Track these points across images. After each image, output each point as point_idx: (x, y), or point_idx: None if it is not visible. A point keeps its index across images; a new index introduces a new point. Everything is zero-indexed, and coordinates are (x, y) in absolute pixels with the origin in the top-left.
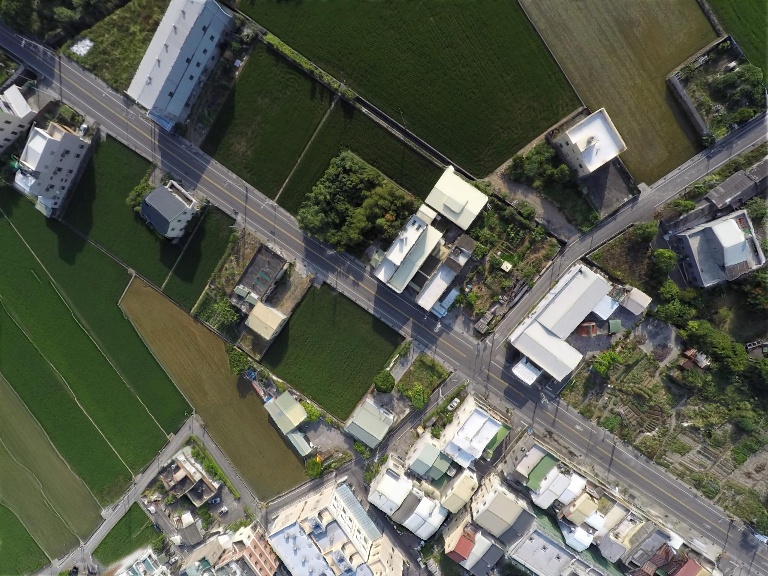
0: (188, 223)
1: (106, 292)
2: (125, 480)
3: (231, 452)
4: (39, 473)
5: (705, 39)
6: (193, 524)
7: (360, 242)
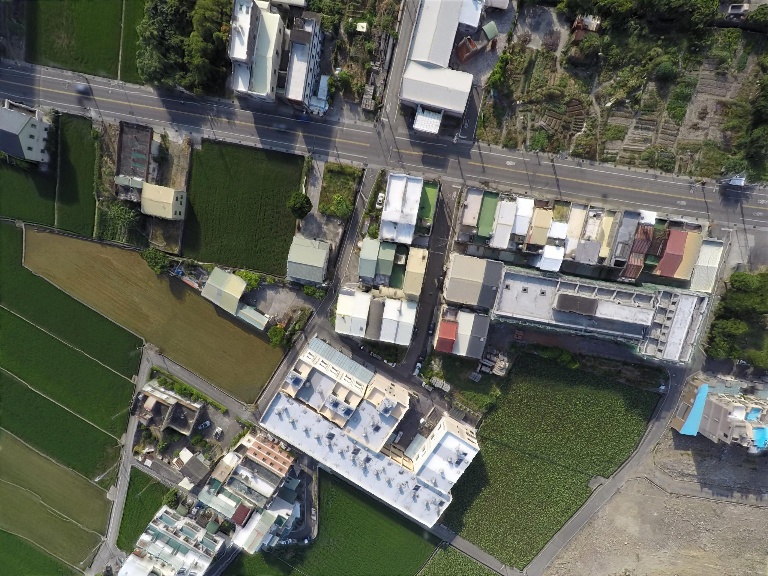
0: (46, 141)
1: (6, 257)
2: (113, 449)
3: (198, 366)
4: (32, 485)
5: None
6: (193, 457)
7: (213, 74)
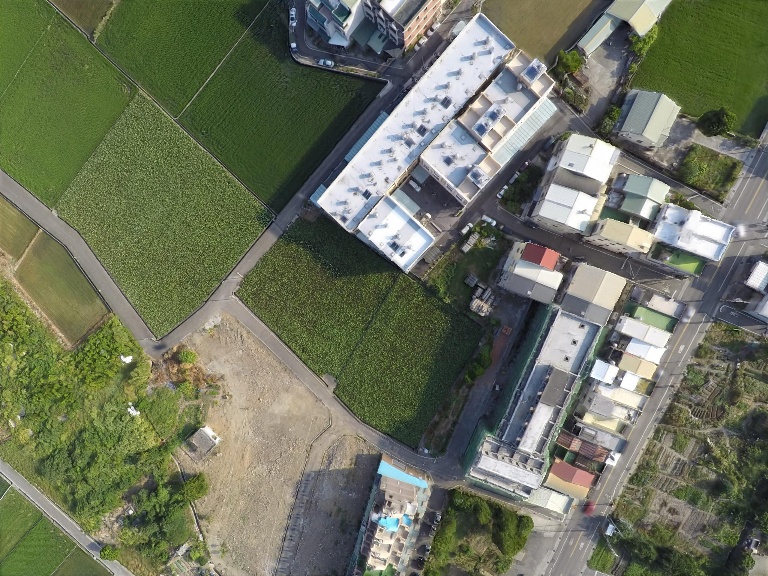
0: None
1: None
2: None
3: None
4: None
5: None
6: None
7: None
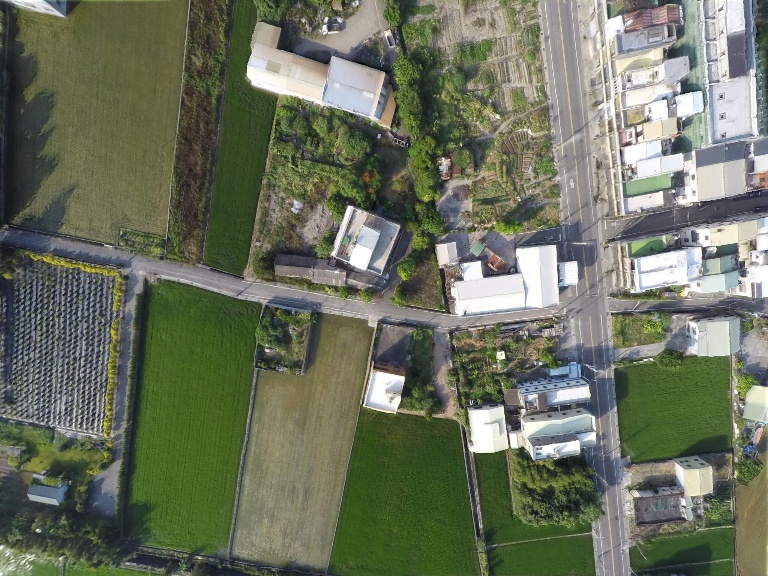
0: None
1: None
2: None
3: None
4: None
5: (266, 375)
6: None
7: (573, 462)
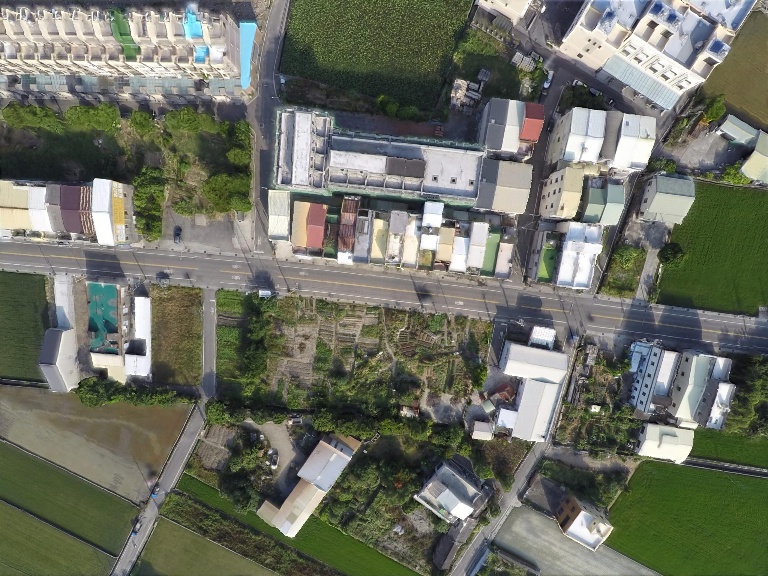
0: None
1: None
2: None
3: None
4: None
5: None
6: None
7: (738, 371)
